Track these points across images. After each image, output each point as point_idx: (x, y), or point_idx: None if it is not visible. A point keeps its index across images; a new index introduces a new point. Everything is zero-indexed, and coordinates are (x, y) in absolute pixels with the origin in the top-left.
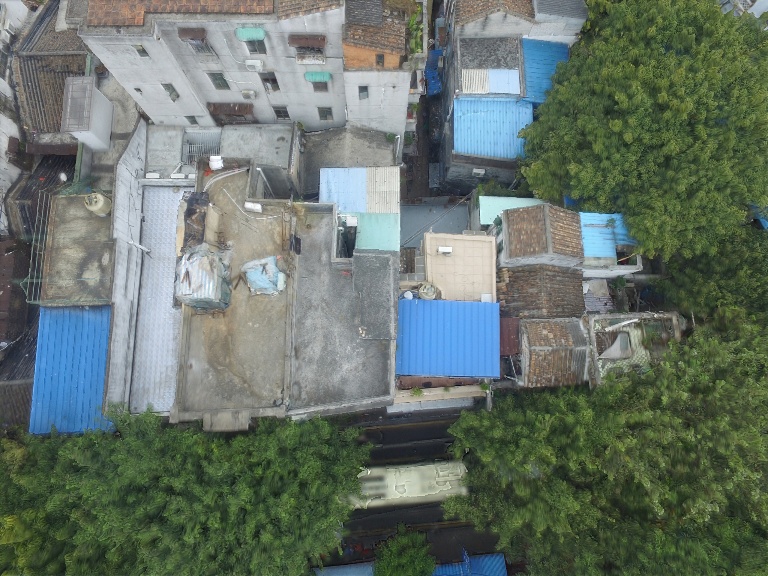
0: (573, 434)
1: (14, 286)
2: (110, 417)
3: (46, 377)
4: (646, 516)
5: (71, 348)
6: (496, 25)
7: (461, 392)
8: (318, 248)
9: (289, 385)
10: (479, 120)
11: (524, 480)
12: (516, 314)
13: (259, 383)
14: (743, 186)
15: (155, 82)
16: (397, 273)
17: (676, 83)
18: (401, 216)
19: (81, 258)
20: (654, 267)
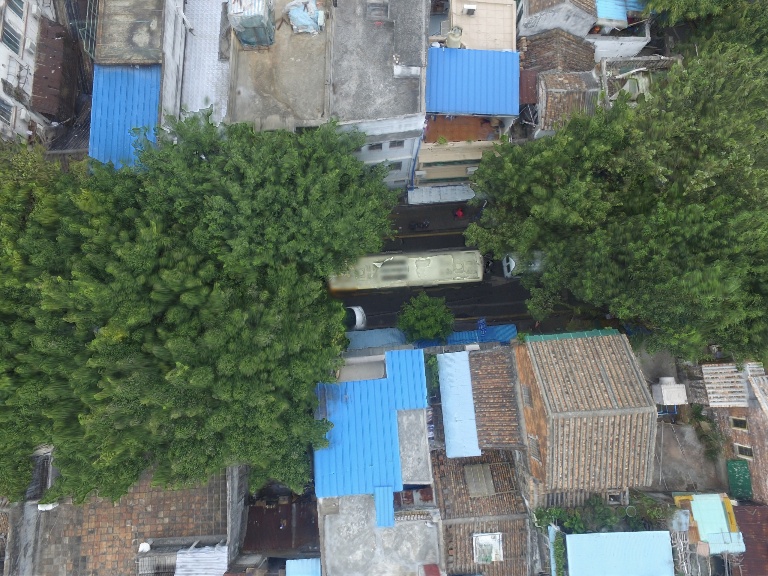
0: (587, 134)
1: (64, 70)
2: (170, 120)
3: (101, 126)
4: (650, 212)
5: (124, 102)
6: None
7: (482, 145)
8: (353, 2)
9: None
10: None
11: None
12: None
13: (301, 108)
14: None
15: None
16: None
17: None
18: None
19: (131, 23)
20: None
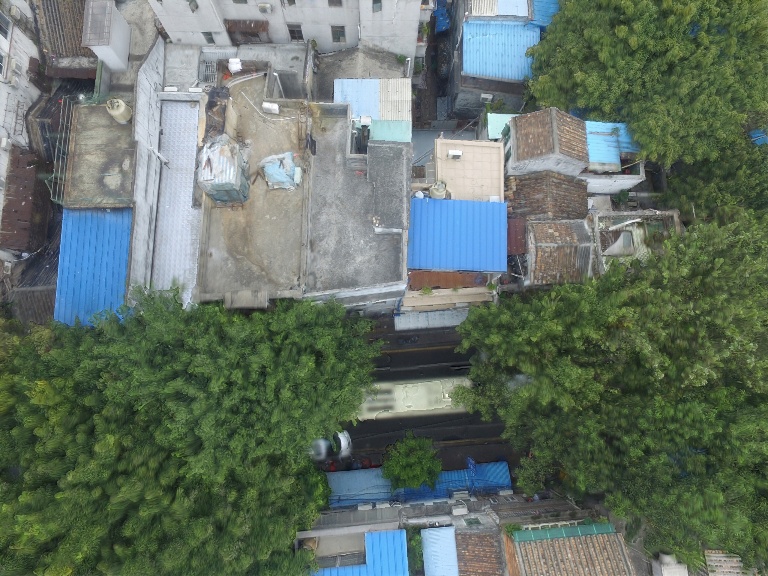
0: (578, 312)
1: (35, 199)
2: (135, 295)
3: (69, 275)
4: (646, 392)
5: (93, 248)
6: None
7: (469, 293)
8: (333, 150)
9: (305, 273)
10: (488, 43)
11: (530, 361)
12: None
13: (276, 271)
14: (744, 92)
15: None
16: (410, 163)
17: None
18: None
19: (102, 163)
20: (656, 187)
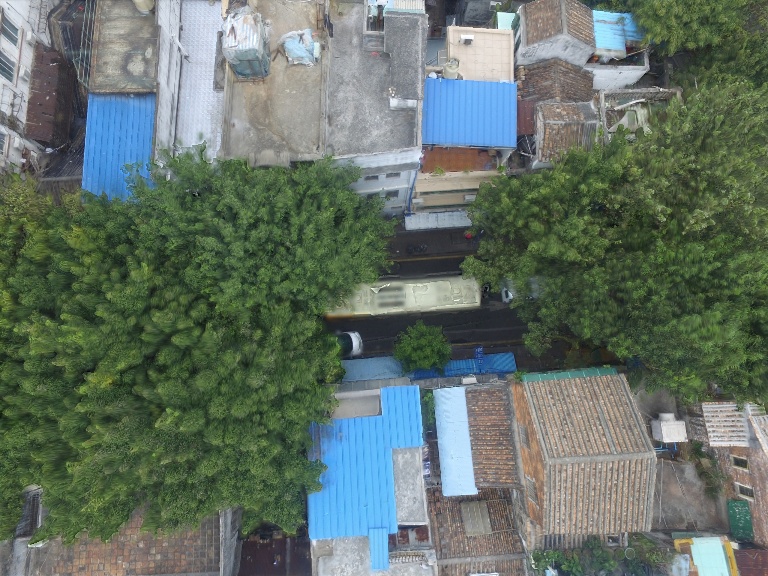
0: (585, 170)
1: (58, 96)
2: (163, 155)
3: (95, 156)
4: (649, 249)
5: (118, 131)
6: None
7: (479, 175)
8: (349, 33)
9: (324, 143)
10: None
11: None
12: None
13: (296, 141)
14: None
15: None
16: (425, 33)
17: None
18: None
19: (126, 52)
20: None
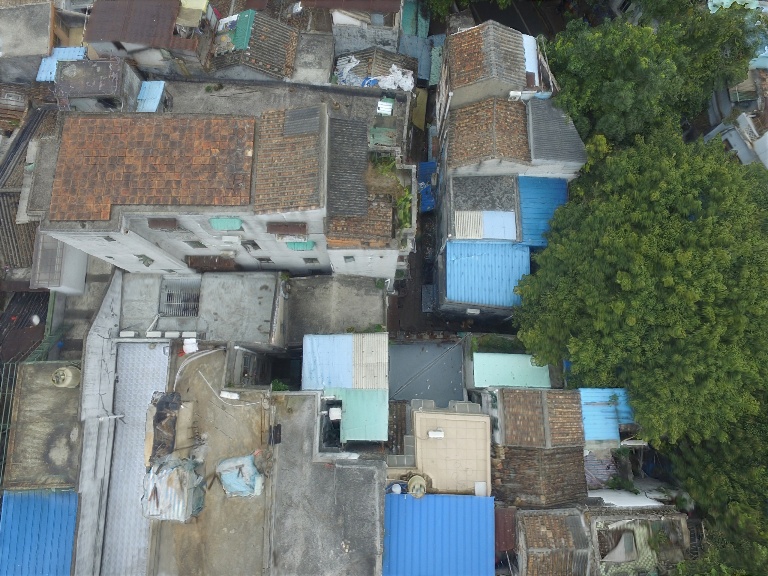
0: None
1: None
2: None
3: (8, 569)
4: None
5: (36, 535)
6: (491, 168)
7: None
8: (300, 435)
9: None
10: (473, 265)
11: None
12: (513, 497)
13: None
14: (755, 371)
15: (127, 253)
16: (383, 487)
17: (682, 264)
18: (392, 356)
19: (48, 433)
20: None
